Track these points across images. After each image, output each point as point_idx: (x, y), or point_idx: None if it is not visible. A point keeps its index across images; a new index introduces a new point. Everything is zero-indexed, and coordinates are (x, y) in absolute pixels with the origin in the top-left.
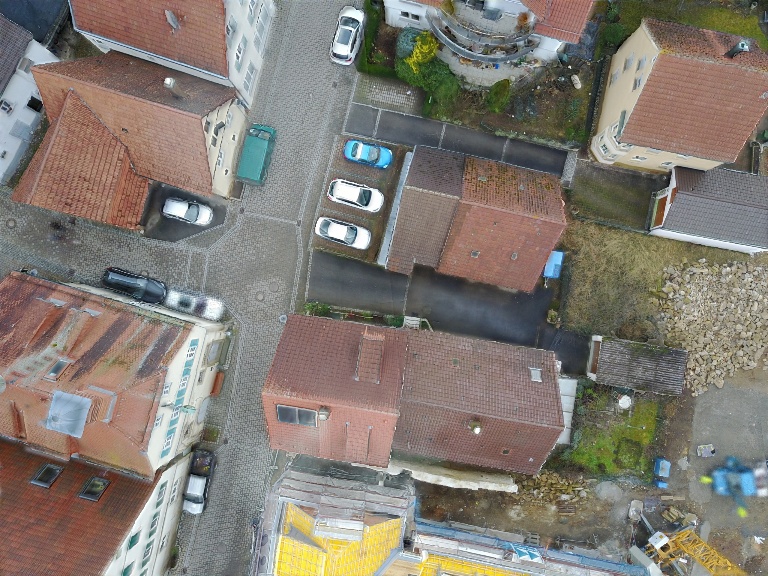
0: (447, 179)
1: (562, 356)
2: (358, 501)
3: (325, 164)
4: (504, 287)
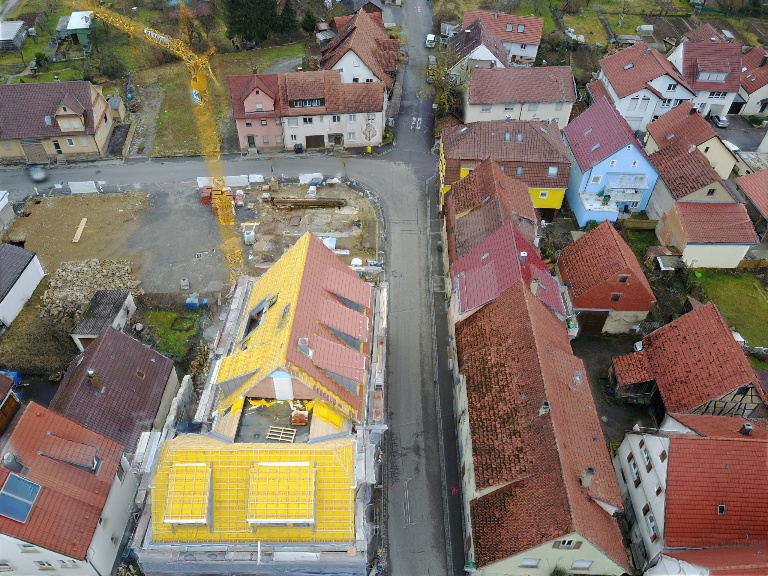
0: None
1: None
2: None
3: None
4: None
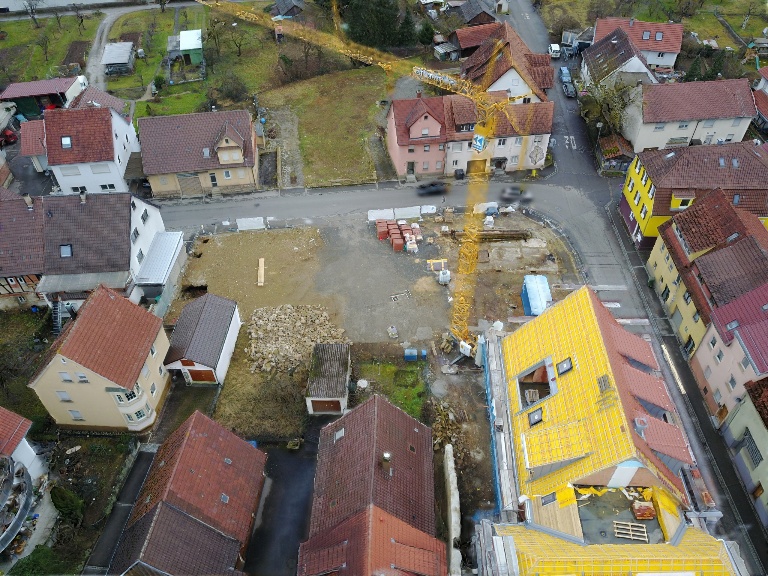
0: (142, 528)
1: None
2: (488, 572)
3: None
4: (267, 491)
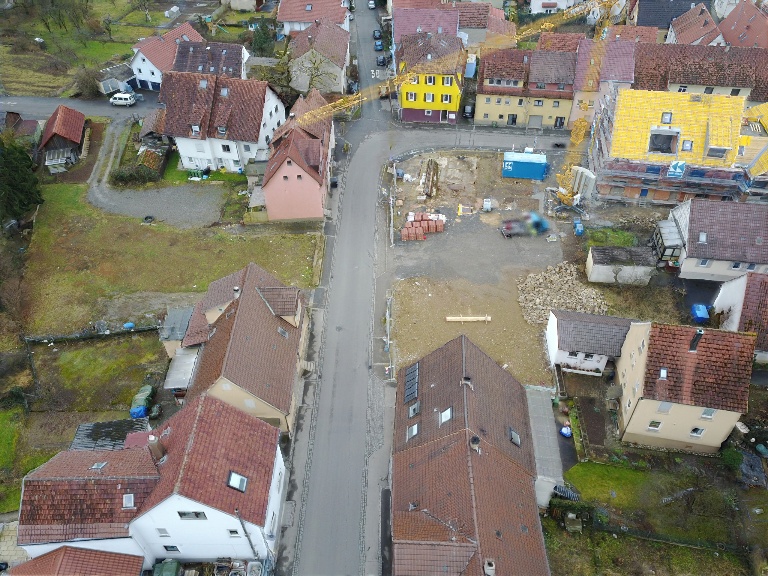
0: None
1: (663, 276)
2: None
3: None
4: None
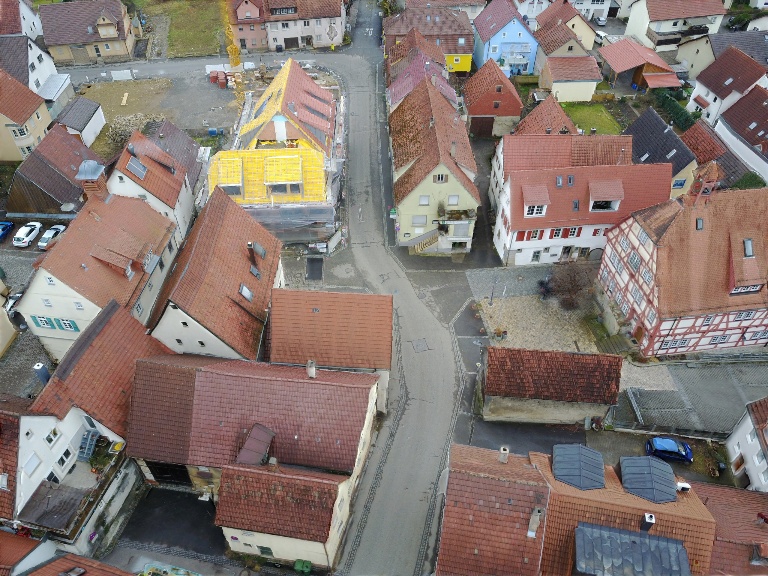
0: None
1: None
2: None
3: (1, 252)
4: None
